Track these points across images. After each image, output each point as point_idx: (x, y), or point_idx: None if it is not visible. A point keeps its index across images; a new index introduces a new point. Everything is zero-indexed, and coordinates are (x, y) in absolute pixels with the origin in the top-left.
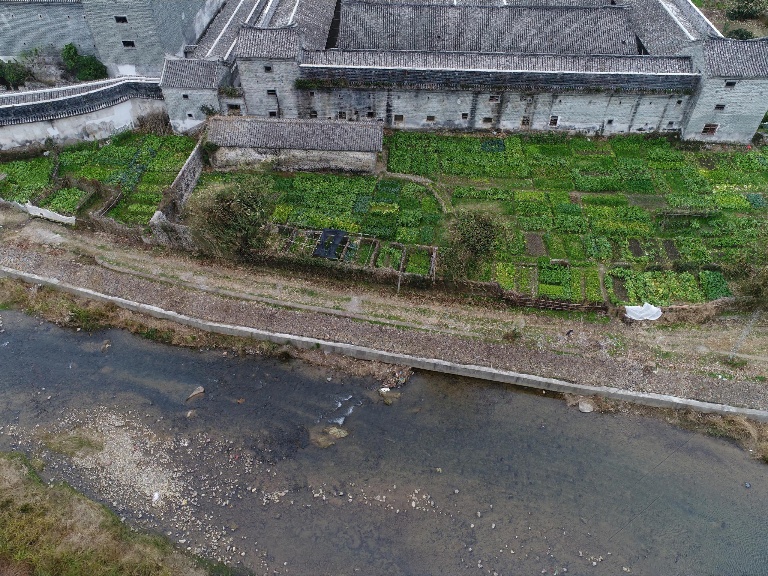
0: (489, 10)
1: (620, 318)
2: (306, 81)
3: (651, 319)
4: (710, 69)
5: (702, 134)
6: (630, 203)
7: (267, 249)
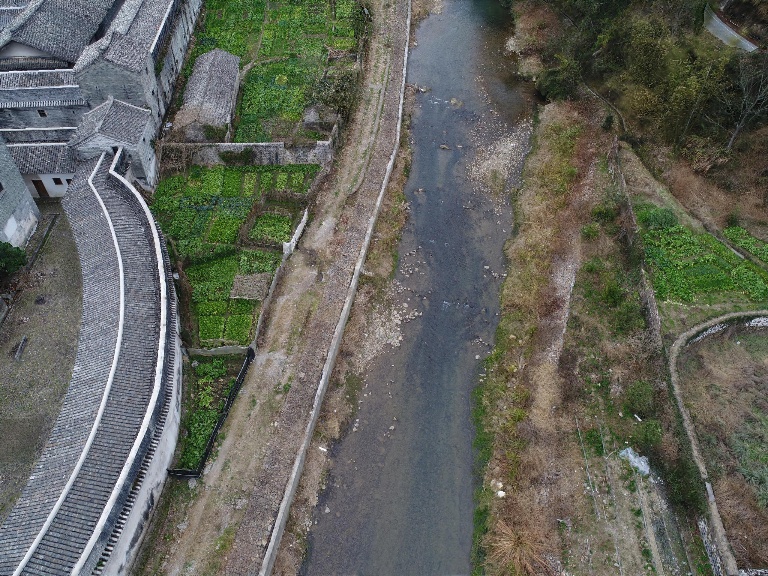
0: None
1: (369, 21)
2: (158, 64)
3: None
4: None
5: None
6: None
7: None
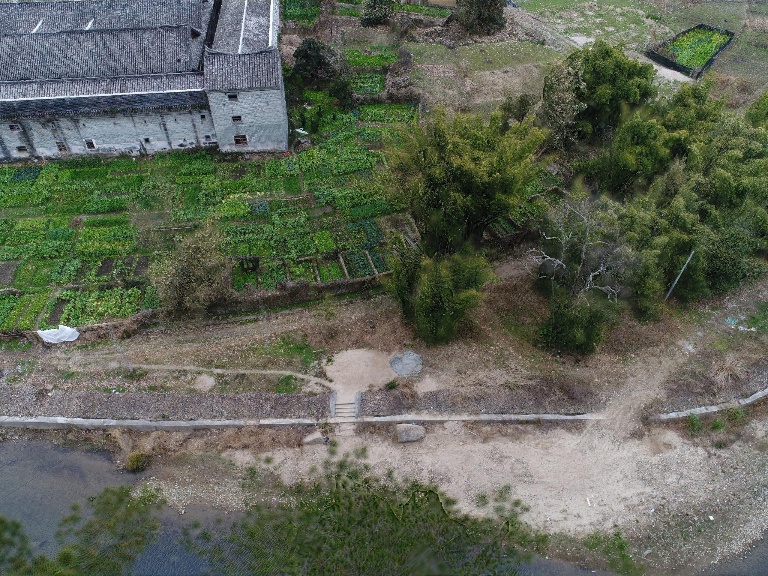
0: (45, 37)
1: (41, 343)
2: None
3: (69, 340)
4: (206, 84)
5: (237, 145)
6: (132, 221)
7: None
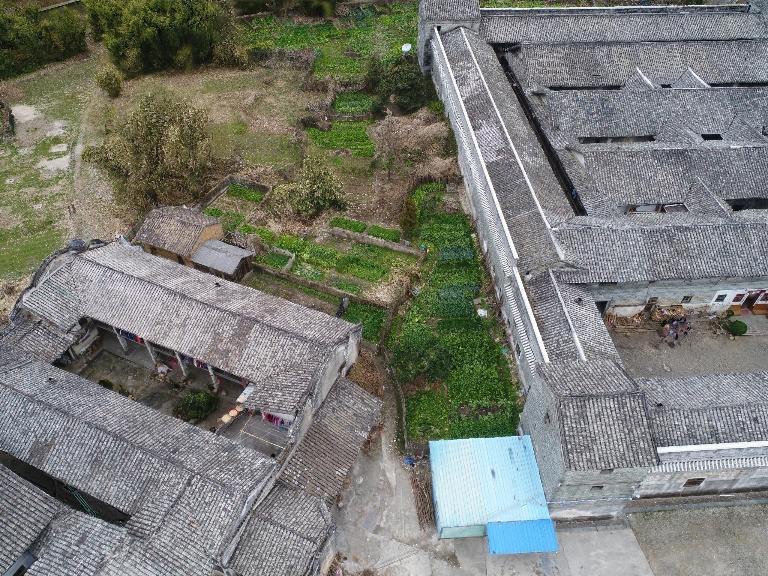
0: None
1: None
2: None
3: None
4: None
5: None
6: None
7: (672, 0)
